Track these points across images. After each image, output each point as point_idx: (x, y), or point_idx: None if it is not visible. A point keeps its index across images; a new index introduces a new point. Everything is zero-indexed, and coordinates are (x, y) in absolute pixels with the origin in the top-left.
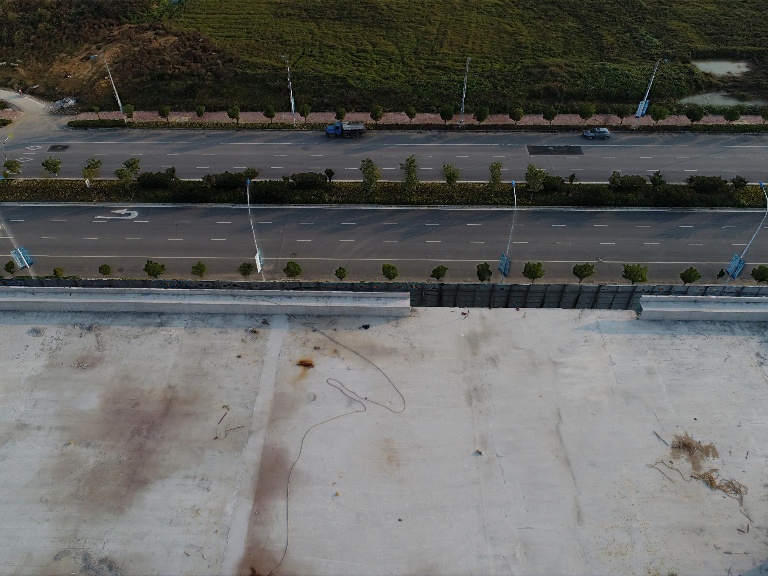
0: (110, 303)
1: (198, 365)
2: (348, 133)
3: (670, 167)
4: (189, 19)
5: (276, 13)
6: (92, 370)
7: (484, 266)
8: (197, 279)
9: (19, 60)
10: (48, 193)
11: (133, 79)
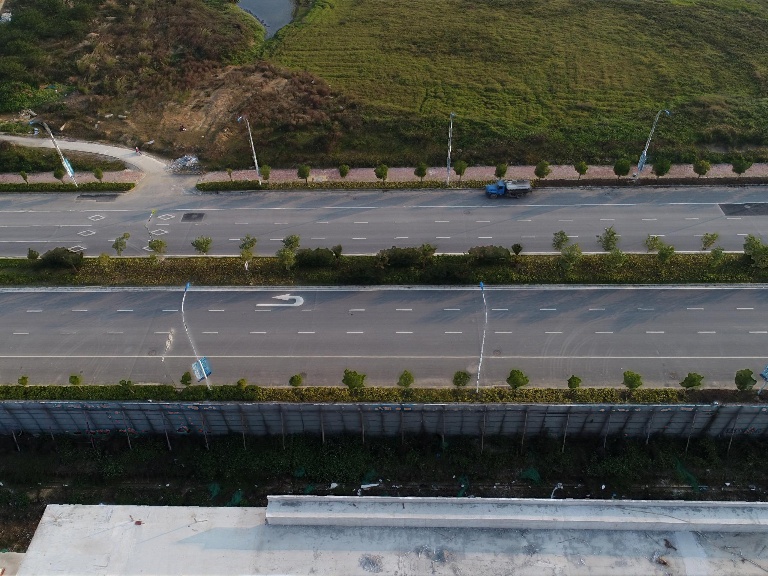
0: (460, 519)
1: None
2: (512, 193)
3: None
4: (292, 57)
5: (384, 48)
6: None
7: (747, 373)
8: (395, 386)
9: (127, 111)
10: (197, 275)
11: (254, 131)
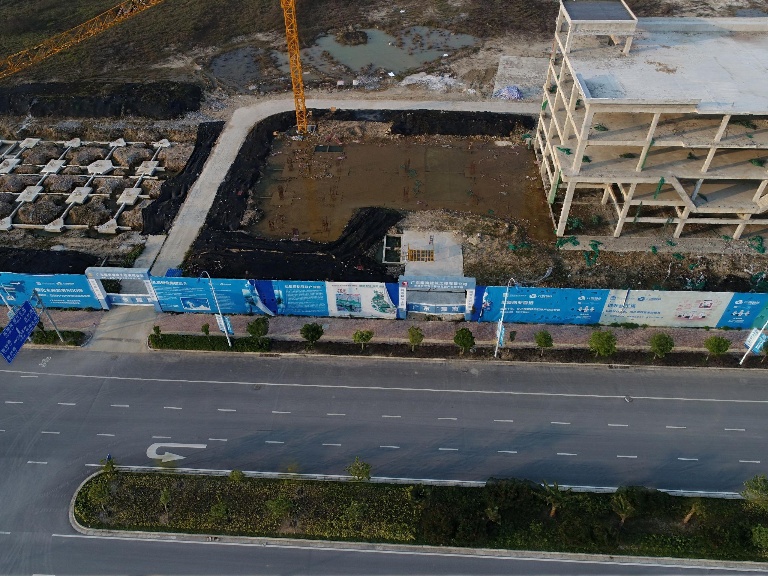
0: None
1: None
2: None
3: None
4: None
5: None
6: None
7: None
8: None
9: None
10: None
11: None
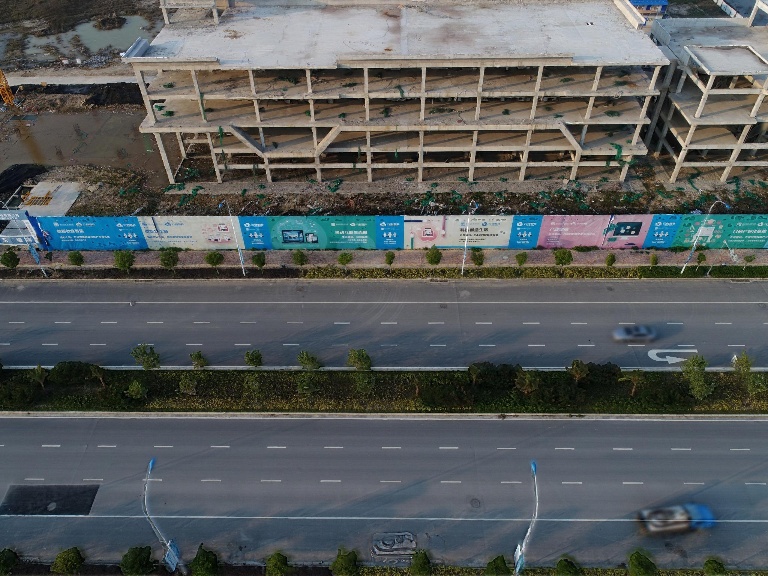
0: None
1: None
2: None
3: None
4: None
5: None
6: None
7: (258, 257)
8: (529, 282)
9: None
10: None
11: None
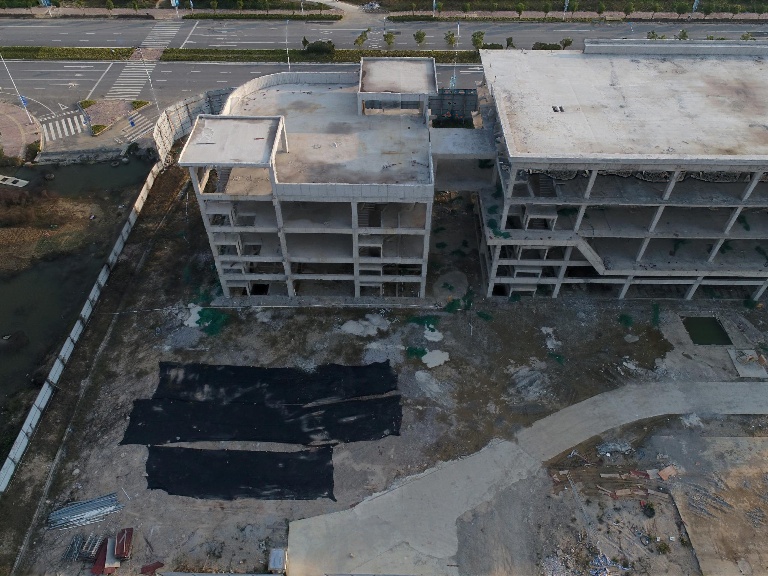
0: (671, 47)
1: (742, 72)
2: (609, 23)
3: None
4: None
5: None
6: (686, 73)
7: None
8: None
9: None
10: None
11: None
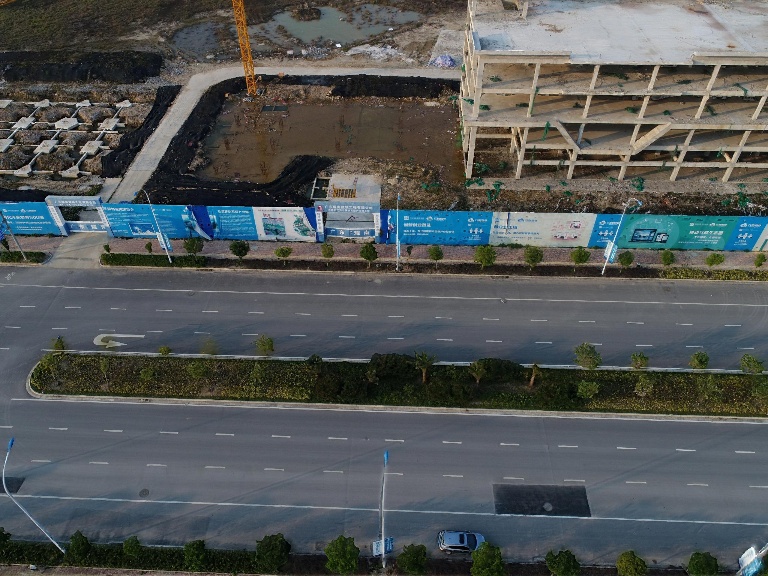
0: None
1: None
2: None
3: (366, 447)
4: None
5: None
6: None
7: None
8: None
9: None
10: None
11: None
